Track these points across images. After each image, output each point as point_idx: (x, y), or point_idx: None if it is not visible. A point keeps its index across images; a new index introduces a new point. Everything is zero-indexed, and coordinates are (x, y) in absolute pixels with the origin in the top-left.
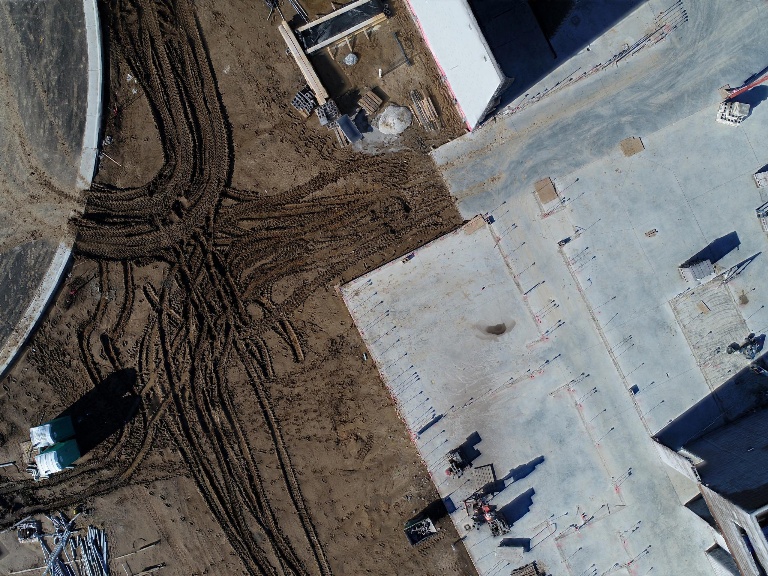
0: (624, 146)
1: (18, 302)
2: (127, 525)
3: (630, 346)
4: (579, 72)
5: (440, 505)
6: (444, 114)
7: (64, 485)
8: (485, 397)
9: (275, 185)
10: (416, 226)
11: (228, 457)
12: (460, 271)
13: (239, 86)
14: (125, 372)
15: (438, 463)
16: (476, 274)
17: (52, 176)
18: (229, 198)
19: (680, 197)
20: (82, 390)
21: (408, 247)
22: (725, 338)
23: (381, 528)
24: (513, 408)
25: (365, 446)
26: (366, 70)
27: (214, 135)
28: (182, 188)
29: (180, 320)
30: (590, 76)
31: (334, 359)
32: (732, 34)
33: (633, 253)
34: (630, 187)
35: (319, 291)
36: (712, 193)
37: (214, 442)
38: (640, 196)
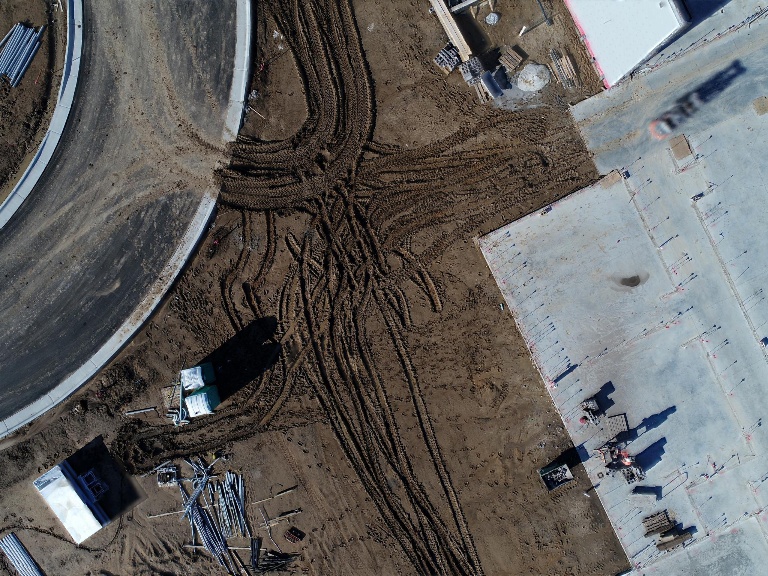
0: (756, 105)
1: (163, 250)
2: (265, 470)
3: (761, 299)
4: (713, 33)
5: (573, 453)
6: (581, 72)
7: (204, 430)
8: (619, 348)
9: (416, 139)
10: (553, 180)
11: (365, 405)
12: (596, 224)
13: (382, 43)
14: (266, 320)
15: (572, 412)
16: (611, 227)
17: (199, 128)
18: (371, 151)
19: None
20: (223, 337)
21: (545, 201)
22: None
23: (514, 476)
24: (646, 359)
25: (500, 395)
26: (506, 29)
27: (357, 90)
28: (325, 141)
29: (320, 270)
30: (724, 37)
31: (471, 309)
32: None
33: (764, 209)
34: (762, 145)
35: (458, 243)
36: None
37: (352, 390)
38: None
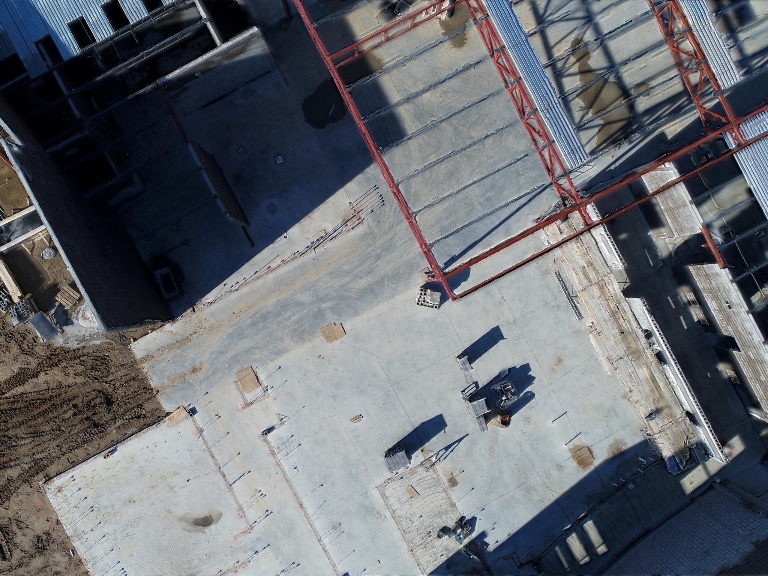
0: (325, 332)
1: None
2: None
3: (340, 533)
4: (277, 260)
5: None
6: None
7: None
8: None
9: None
10: (119, 419)
11: None
12: (164, 464)
13: None
14: None
15: None
16: (181, 466)
17: None
18: None
19: (384, 381)
20: None
21: (112, 440)
22: (436, 522)
23: None
24: None
25: None
26: None
27: None
28: None
29: None
30: (288, 263)
31: (41, 556)
32: (429, 217)
33: (339, 439)
34: (333, 373)
35: (24, 488)
36: (416, 376)
37: None
38: (344, 382)
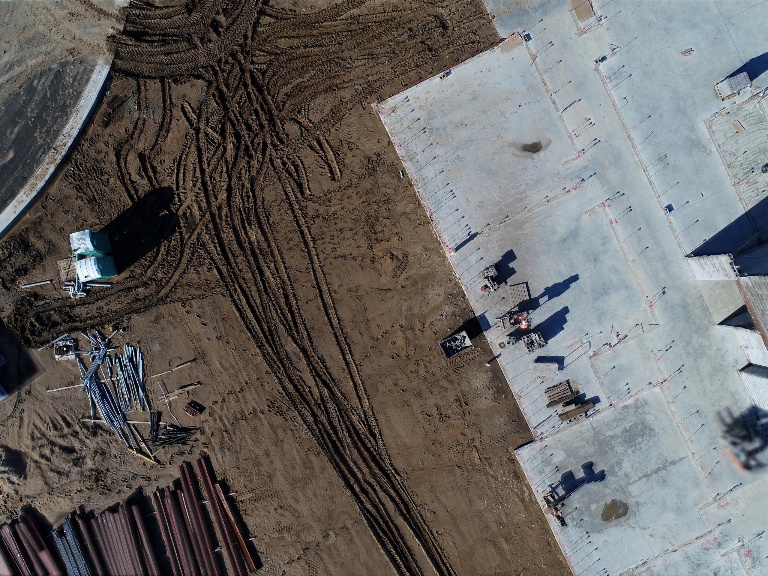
0: None
1: (56, 120)
2: (163, 343)
3: (665, 165)
4: None
5: (475, 324)
6: None
7: (101, 303)
8: (521, 215)
9: (313, 3)
10: (453, 44)
11: (264, 276)
12: (497, 89)
13: None
14: (162, 191)
15: (473, 281)
16: (513, 92)
17: None
18: (267, 16)
19: (716, 16)
20: (119, 208)
21: (445, 65)
22: (760, 158)
23: (416, 347)
24: (548, 226)
25: (401, 264)
26: None
27: None
28: (220, 7)
29: (217, 139)
30: None
31: (370, 177)
32: None
33: (669, 72)
34: (667, 6)
35: (356, 109)
36: (748, 12)
37: (250, 261)
38: (676, 15)
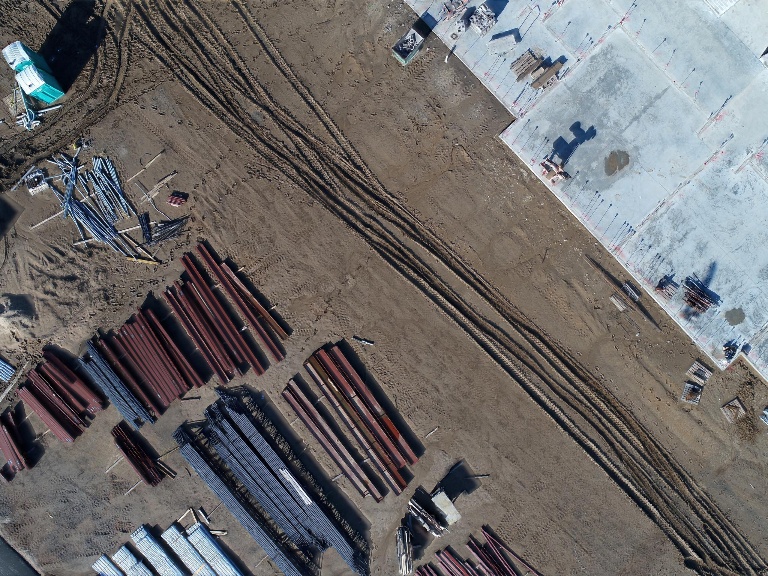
0: None
1: None
2: (129, 145)
3: None
4: None
5: (421, 25)
6: None
7: (57, 126)
8: None
9: None
10: None
11: (205, 49)
12: None
13: None
14: None
15: None
16: None
17: None
18: None
19: None
20: (46, 29)
21: None
22: None
23: (372, 68)
24: None
25: None
26: None
27: None
28: None
29: None
30: None
31: None
32: None
33: None
34: None
35: None
36: None
37: (187, 39)
38: None
